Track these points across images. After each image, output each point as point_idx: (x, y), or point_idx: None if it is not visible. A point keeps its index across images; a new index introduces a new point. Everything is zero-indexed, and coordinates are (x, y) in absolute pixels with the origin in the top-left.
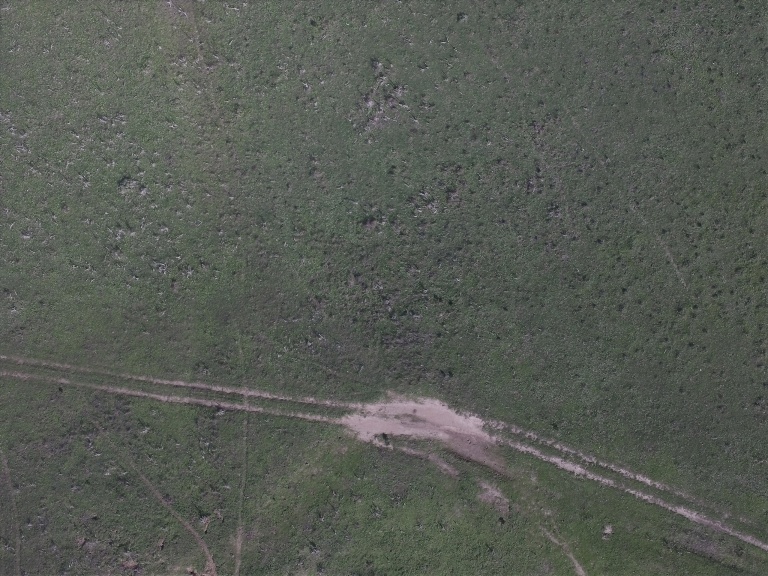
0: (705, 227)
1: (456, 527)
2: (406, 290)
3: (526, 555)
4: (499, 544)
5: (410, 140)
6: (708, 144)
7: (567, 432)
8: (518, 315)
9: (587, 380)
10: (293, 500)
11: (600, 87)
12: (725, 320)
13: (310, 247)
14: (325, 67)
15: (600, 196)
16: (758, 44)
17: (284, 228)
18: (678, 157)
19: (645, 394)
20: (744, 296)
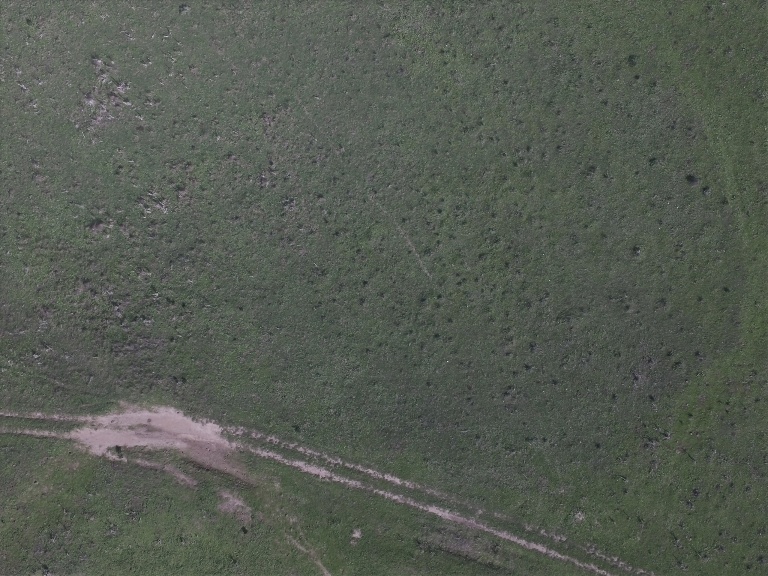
0: (446, 214)
1: (198, 540)
2: (137, 295)
3: (272, 565)
4: (243, 555)
5: (137, 139)
6: (445, 128)
7: (310, 434)
8: (255, 314)
9: (329, 378)
10: (23, 521)
11: (331, 75)
12: (471, 308)
13: (35, 255)
14: (44, 67)
15: (336, 187)
16: (491, 24)
17: (7, 236)
18: (415, 143)
19: (391, 389)
20: (490, 283)
